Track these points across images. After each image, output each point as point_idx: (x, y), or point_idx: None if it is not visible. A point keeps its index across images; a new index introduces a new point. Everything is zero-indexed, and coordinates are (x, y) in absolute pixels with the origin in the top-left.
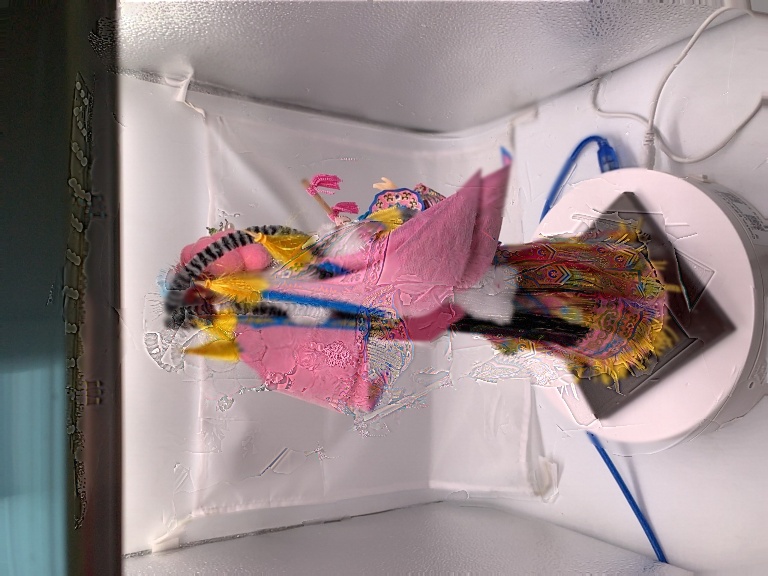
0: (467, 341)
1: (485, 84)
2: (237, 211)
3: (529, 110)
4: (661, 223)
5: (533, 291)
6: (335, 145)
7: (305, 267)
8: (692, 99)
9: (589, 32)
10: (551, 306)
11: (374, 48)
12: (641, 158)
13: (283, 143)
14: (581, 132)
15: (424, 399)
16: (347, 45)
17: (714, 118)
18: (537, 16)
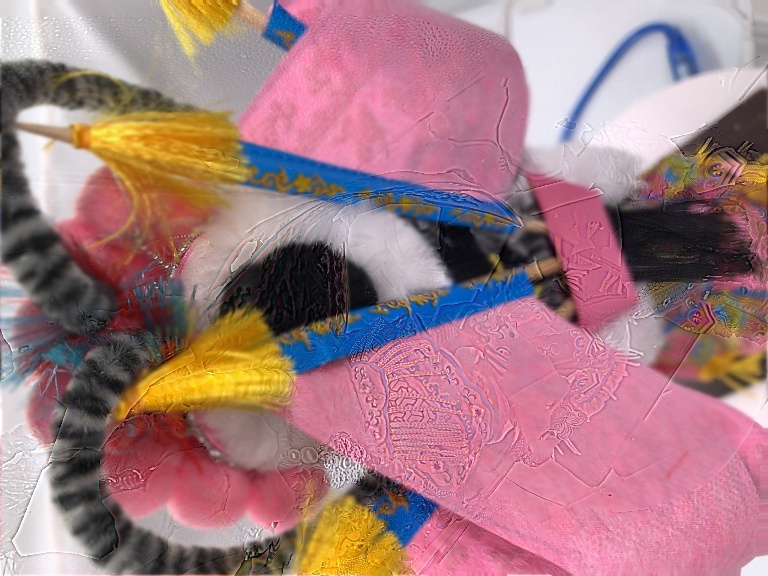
0: (525, 374)
1: (324, 128)
2: (23, 342)
3: (377, 153)
4: (609, 203)
5: (699, 205)
6: (156, 223)
7: (254, 296)
8: (533, 114)
9: (425, 52)
10: (720, 230)
11: (183, 92)
12: (502, 185)
13: (79, 231)
14: (437, 167)
15: (452, 509)
16: (147, 89)
17: (560, 128)
18: (370, 36)
